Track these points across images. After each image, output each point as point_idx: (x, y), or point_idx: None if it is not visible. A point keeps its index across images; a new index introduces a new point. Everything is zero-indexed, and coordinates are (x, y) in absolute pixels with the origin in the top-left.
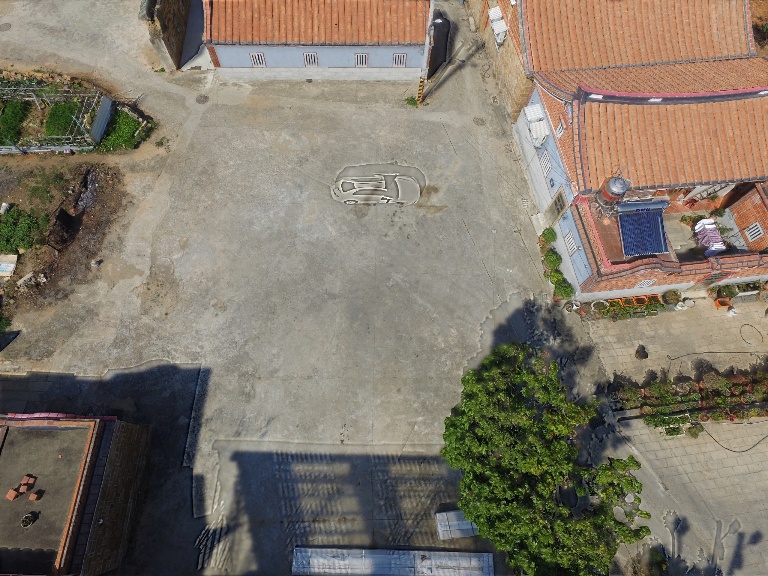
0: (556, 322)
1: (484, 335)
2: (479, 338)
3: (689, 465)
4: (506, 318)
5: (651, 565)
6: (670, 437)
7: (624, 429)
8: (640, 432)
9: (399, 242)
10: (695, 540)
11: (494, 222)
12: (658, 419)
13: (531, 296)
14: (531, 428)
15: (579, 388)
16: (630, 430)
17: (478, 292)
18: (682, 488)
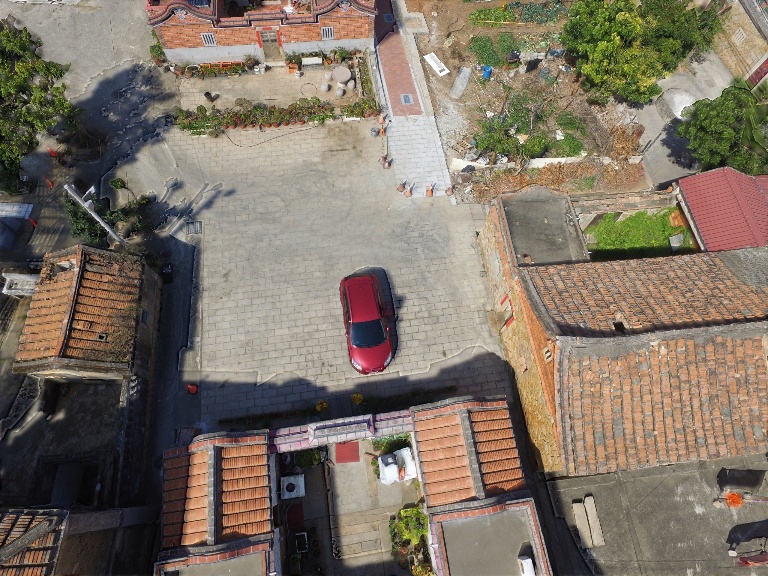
0: (152, 77)
1: (91, 84)
2: (86, 86)
3: (202, 153)
4: (114, 75)
5: (139, 204)
6: (195, 137)
7: (163, 133)
8: (175, 135)
9: (50, 28)
10: (183, 193)
11: (135, 18)
12: (187, 124)
13: (141, 62)
14: (7, 74)
15: (147, 114)
16: (168, 134)
17: (99, 59)
18: (189, 166)
